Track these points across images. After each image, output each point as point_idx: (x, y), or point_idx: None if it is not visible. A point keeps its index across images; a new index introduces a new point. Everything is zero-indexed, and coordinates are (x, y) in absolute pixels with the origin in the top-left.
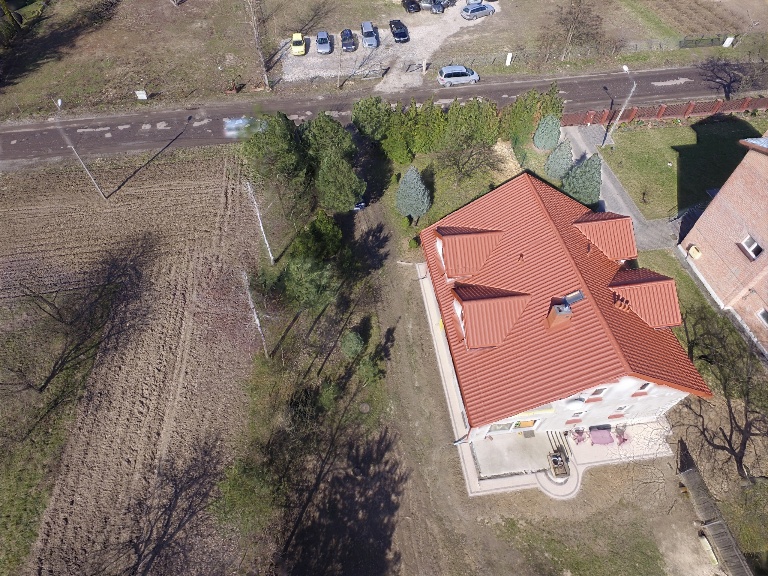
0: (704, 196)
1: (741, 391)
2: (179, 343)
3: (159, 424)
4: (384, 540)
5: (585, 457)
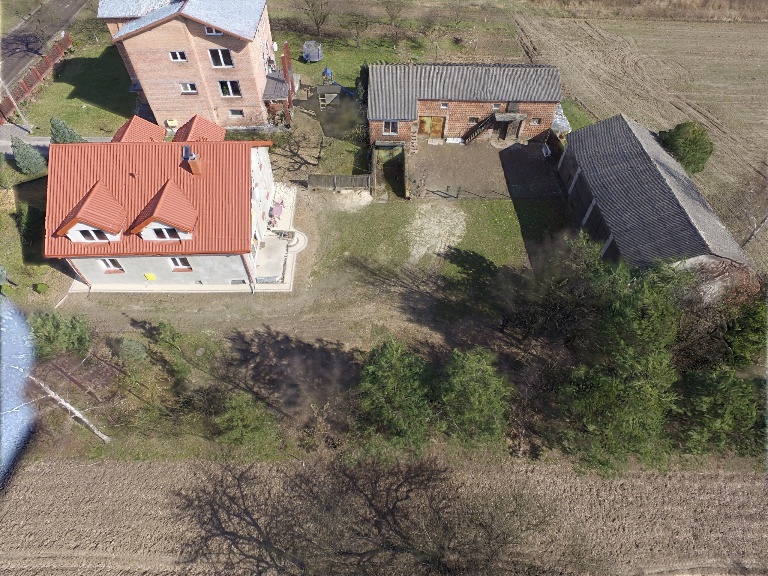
0: (127, 104)
1: (272, 146)
2: (22, 568)
3: (132, 574)
4: (306, 348)
5: (286, 225)
